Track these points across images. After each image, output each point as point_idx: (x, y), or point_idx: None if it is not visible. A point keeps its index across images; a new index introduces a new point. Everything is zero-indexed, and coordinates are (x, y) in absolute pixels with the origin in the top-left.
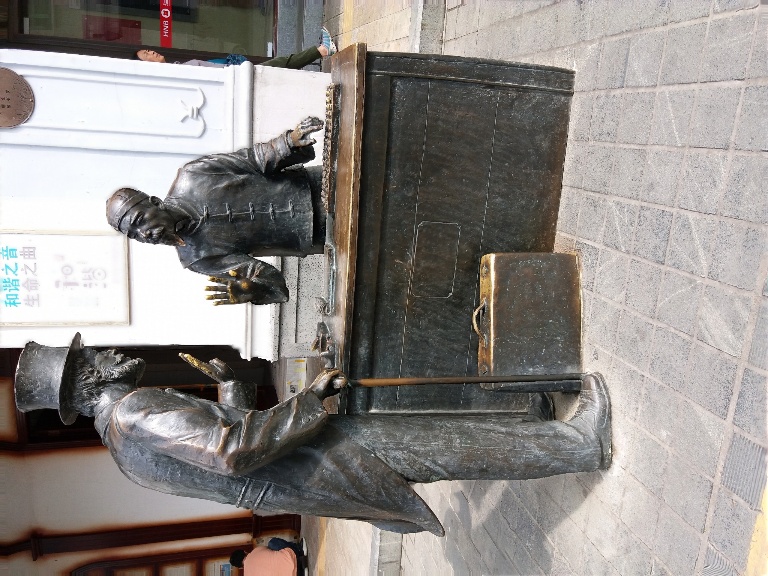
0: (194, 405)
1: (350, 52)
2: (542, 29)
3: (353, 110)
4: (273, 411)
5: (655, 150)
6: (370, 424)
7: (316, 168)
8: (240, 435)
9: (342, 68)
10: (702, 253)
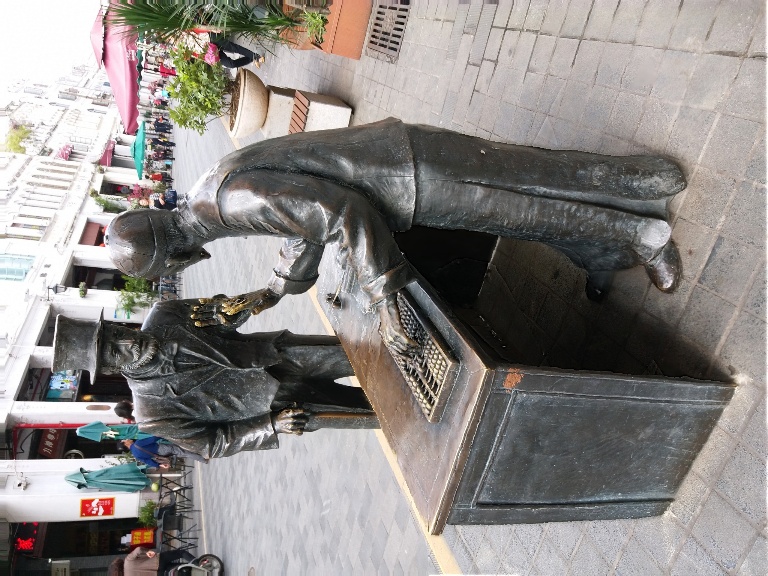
0: (193, 430)
1: (436, 498)
2: (759, 471)
3: (407, 470)
4: (244, 443)
5: (564, 570)
6: (311, 422)
7: (435, 209)
8: (218, 454)
9: (444, 443)
10: (510, 568)
